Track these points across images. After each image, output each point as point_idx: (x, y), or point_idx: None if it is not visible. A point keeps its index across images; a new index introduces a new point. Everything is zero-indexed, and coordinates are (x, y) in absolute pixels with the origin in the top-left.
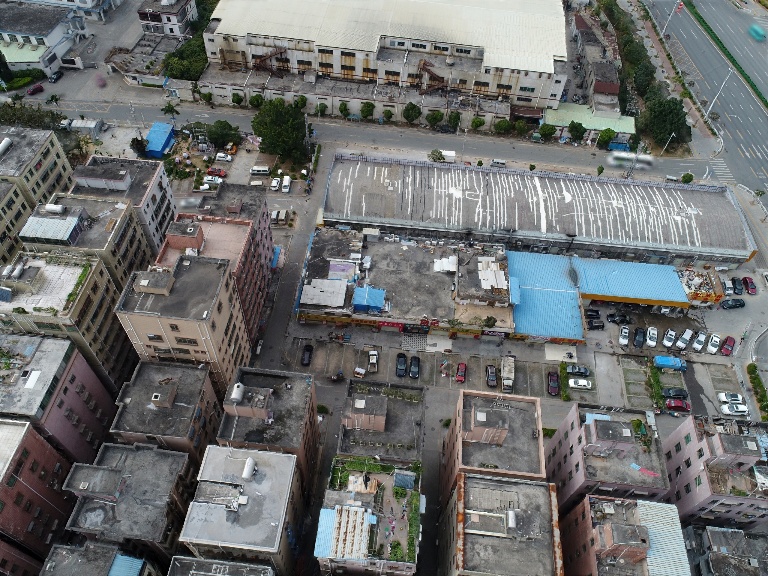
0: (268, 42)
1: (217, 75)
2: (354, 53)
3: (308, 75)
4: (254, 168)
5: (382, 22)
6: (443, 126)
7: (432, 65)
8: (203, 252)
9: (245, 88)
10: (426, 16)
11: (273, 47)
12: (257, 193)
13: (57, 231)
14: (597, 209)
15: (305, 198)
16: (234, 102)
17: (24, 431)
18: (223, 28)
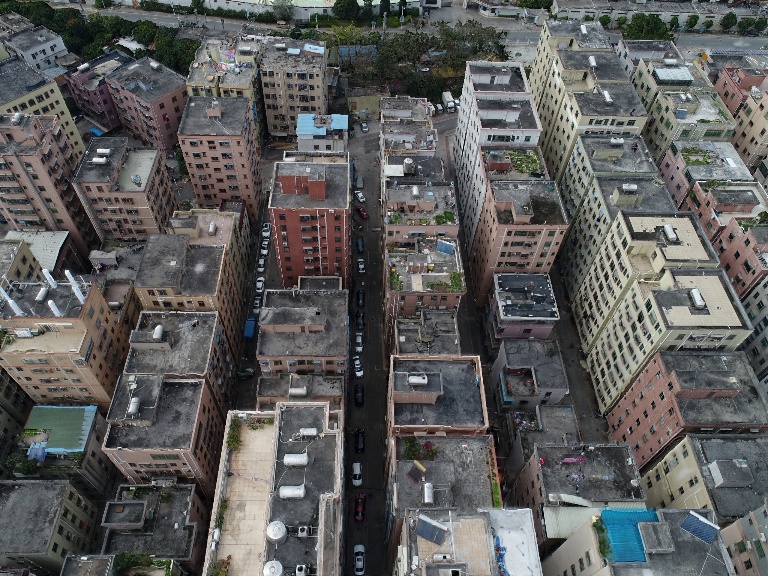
0: None
1: (568, 2)
2: None
3: None
4: None
5: None
6: (751, 31)
7: None
8: (760, 90)
9: (596, 10)
10: None
11: None
12: (735, 61)
13: (682, 75)
14: None
15: None
16: None
17: (761, 186)
18: None
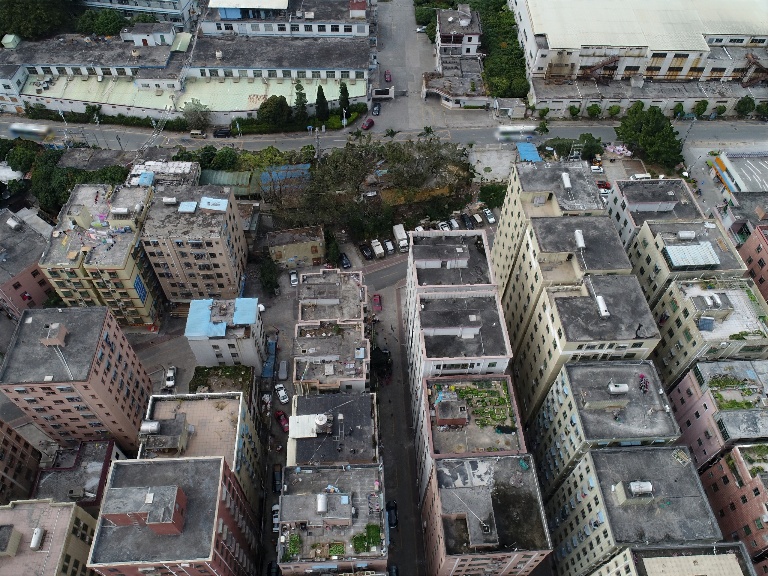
0: (598, 52)
1: (548, 90)
2: (688, 54)
3: (638, 80)
4: (637, 176)
5: (694, 21)
6: None
7: (759, 58)
8: None
9: (583, 99)
10: (728, 11)
11: (604, 56)
12: (766, 198)
13: (704, 257)
14: None
15: (700, 199)
16: (573, 114)
17: None
18: (555, 43)
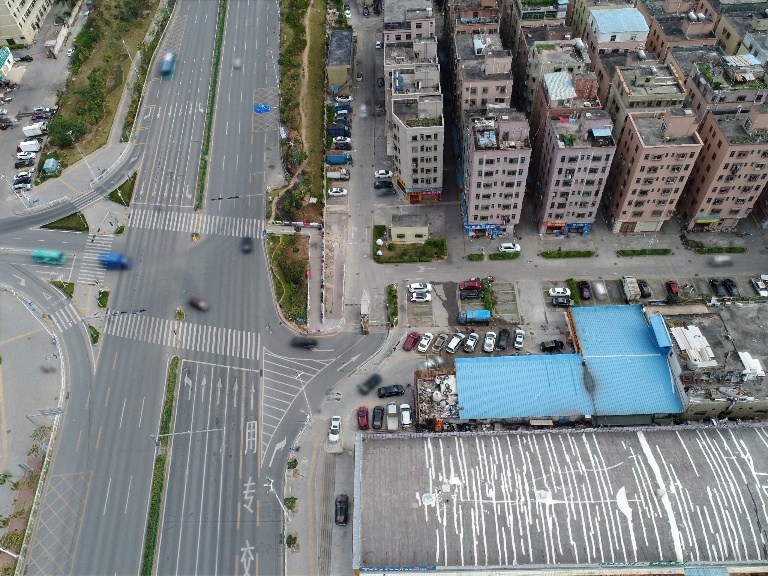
0: None
1: None
2: None
3: None
4: None
5: None
6: None
7: None
8: None
9: None
10: None
11: None
12: None
13: None
14: (575, 480)
15: None
16: None
17: None
18: None
